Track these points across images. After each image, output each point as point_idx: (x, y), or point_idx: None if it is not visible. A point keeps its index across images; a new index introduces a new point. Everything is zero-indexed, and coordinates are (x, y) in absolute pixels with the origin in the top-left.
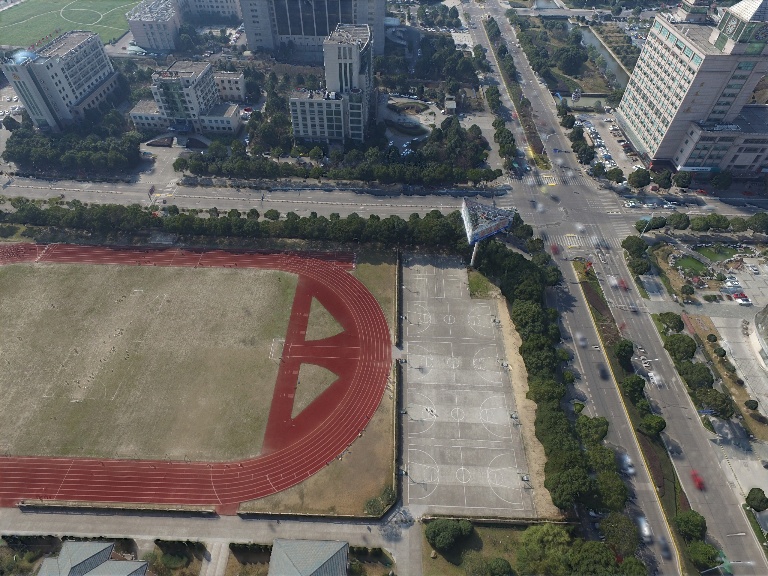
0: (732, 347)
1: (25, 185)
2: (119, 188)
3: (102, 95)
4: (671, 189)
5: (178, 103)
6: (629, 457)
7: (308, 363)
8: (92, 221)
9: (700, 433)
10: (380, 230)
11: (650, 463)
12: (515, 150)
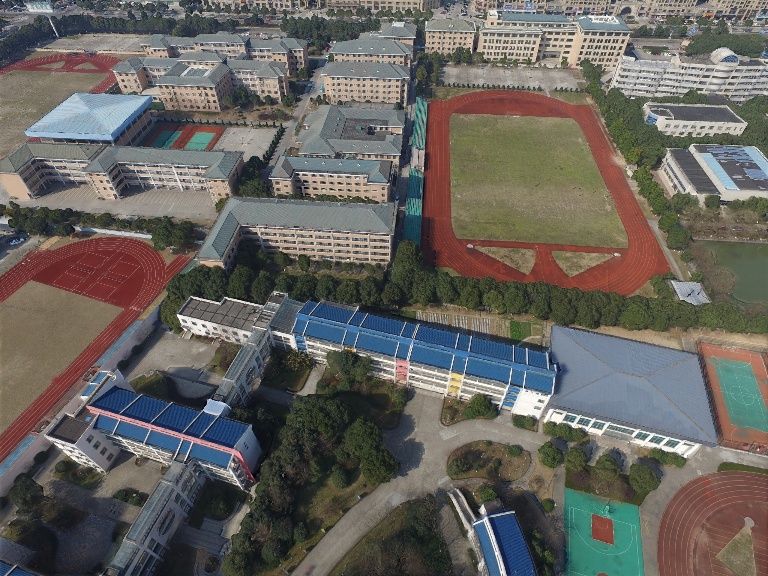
0: None
1: None
2: None
3: None
4: None
5: None
6: None
7: (74, 67)
8: None
9: None
10: (12, 40)
11: None
12: None
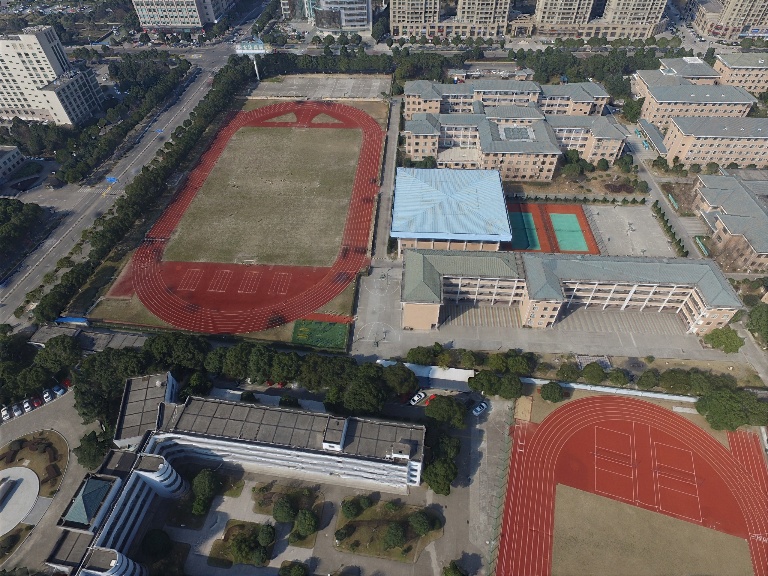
0: None
1: (11, 289)
2: (73, 219)
3: None
4: None
5: None
6: None
7: (311, 120)
8: (144, 197)
9: None
10: (227, 88)
11: None
12: None
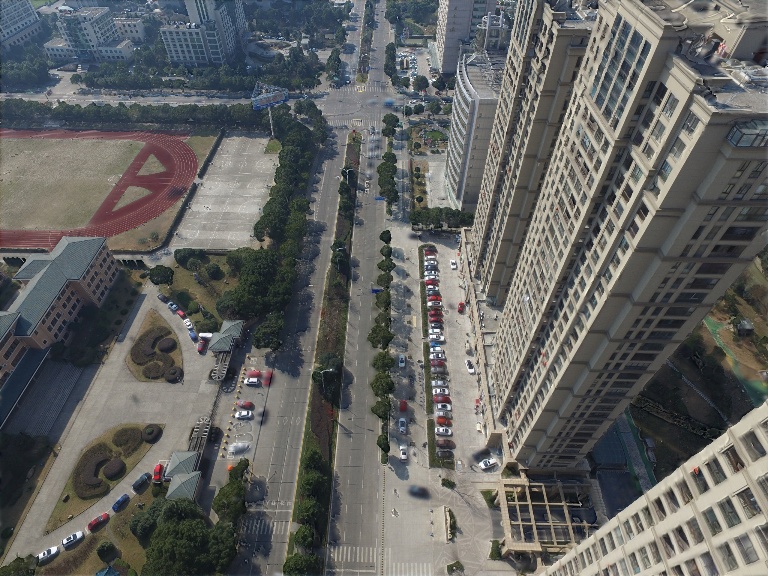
0: (432, 176)
1: None
2: (29, 96)
3: (27, 36)
4: (451, 93)
5: (80, 37)
6: (327, 227)
7: (134, 186)
8: None
9: (381, 216)
10: (206, 111)
11: (337, 228)
12: (336, 67)
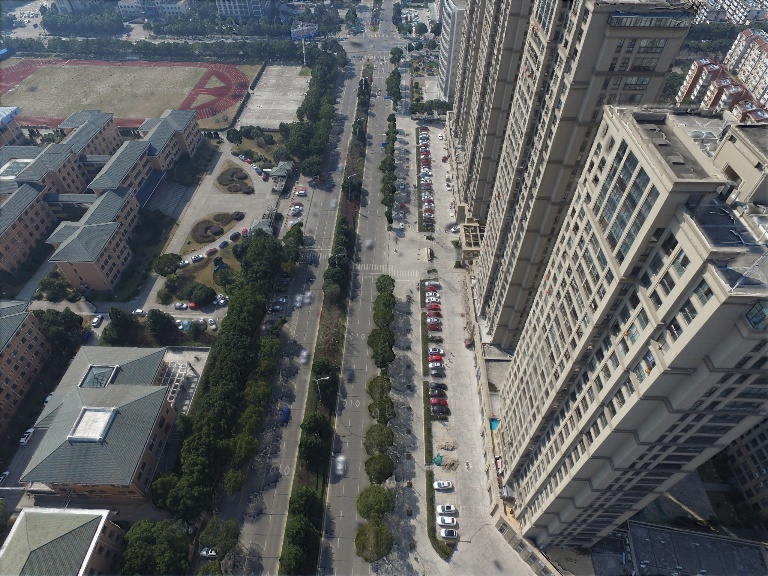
0: (428, 89)
1: None
2: None
3: None
4: None
5: None
6: (348, 117)
7: (203, 94)
8: (94, 45)
9: (389, 112)
10: (254, 45)
11: None
12: (353, 18)
